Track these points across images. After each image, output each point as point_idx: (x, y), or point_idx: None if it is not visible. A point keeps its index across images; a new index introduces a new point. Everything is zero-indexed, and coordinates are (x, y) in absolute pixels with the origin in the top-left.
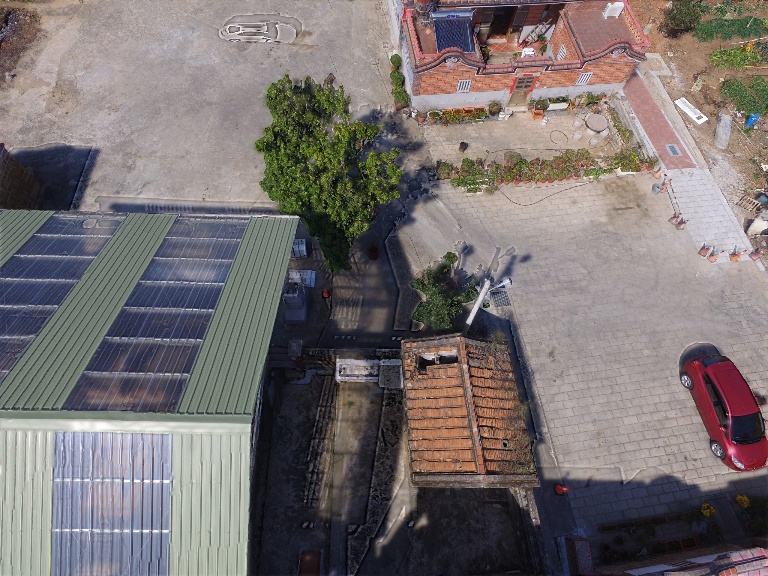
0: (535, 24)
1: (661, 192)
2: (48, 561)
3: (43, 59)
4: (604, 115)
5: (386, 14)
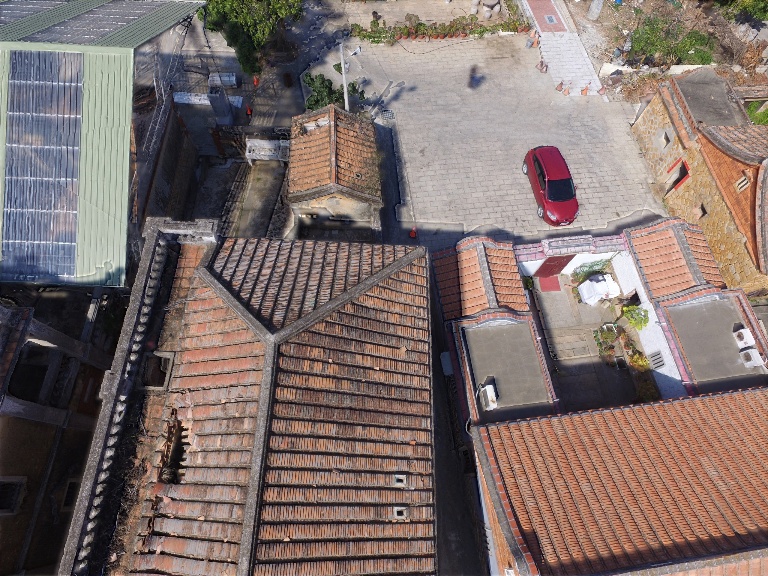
0: None
1: (533, 47)
2: (5, 132)
3: None
4: None
5: None
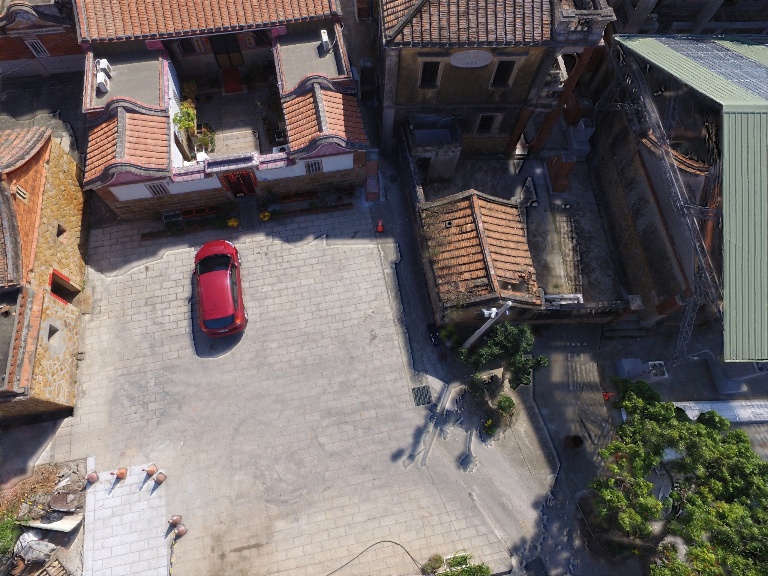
0: None
1: None
2: None
3: None
4: None
5: None
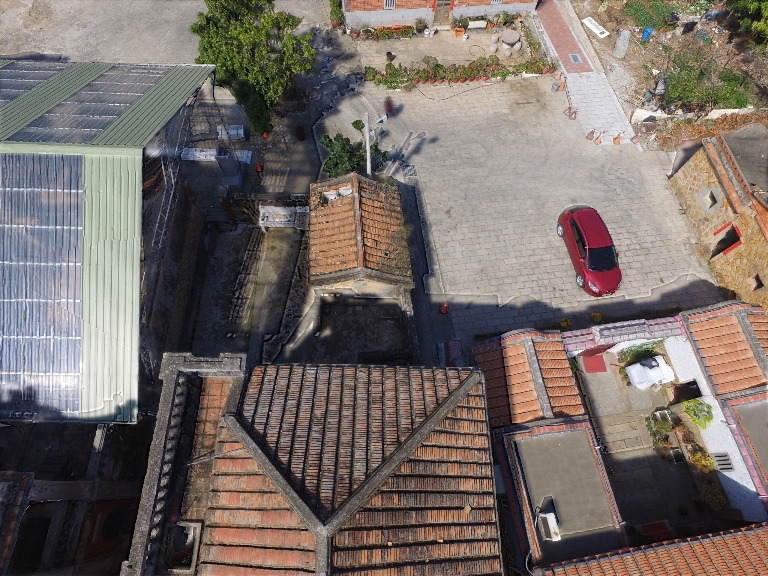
0: None
1: (559, 90)
2: None
3: None
4: (518, 32)
5: None
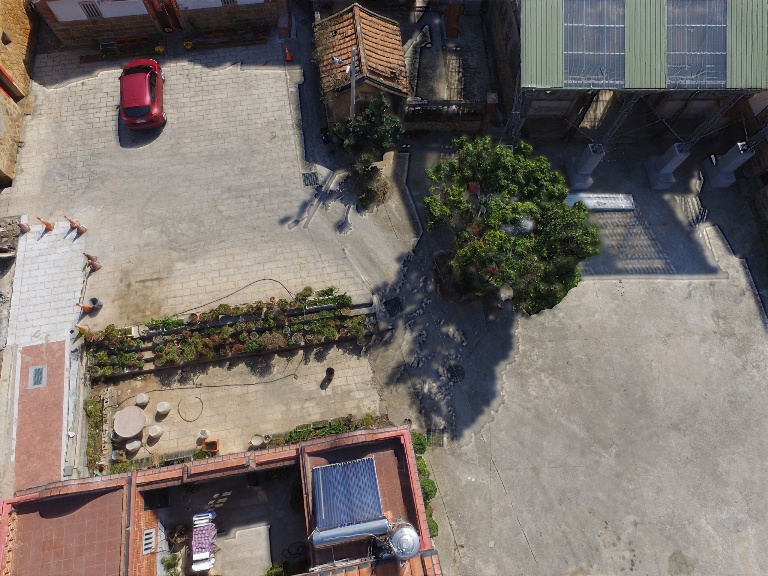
0: None
1: None
2: None
3: None
4: (110, 449)
5: None
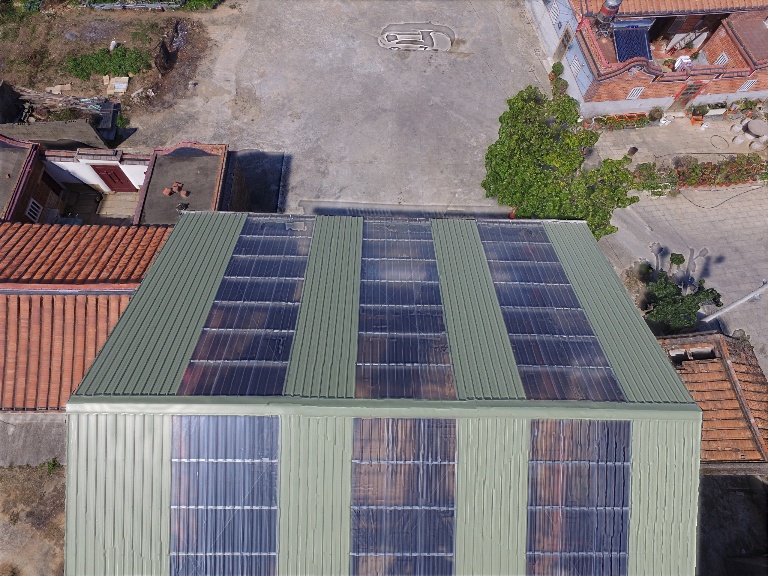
0: (687, 32)
1: None
2: (524, 535)
3: (219, 68)
4: None
5: (531, 22)
